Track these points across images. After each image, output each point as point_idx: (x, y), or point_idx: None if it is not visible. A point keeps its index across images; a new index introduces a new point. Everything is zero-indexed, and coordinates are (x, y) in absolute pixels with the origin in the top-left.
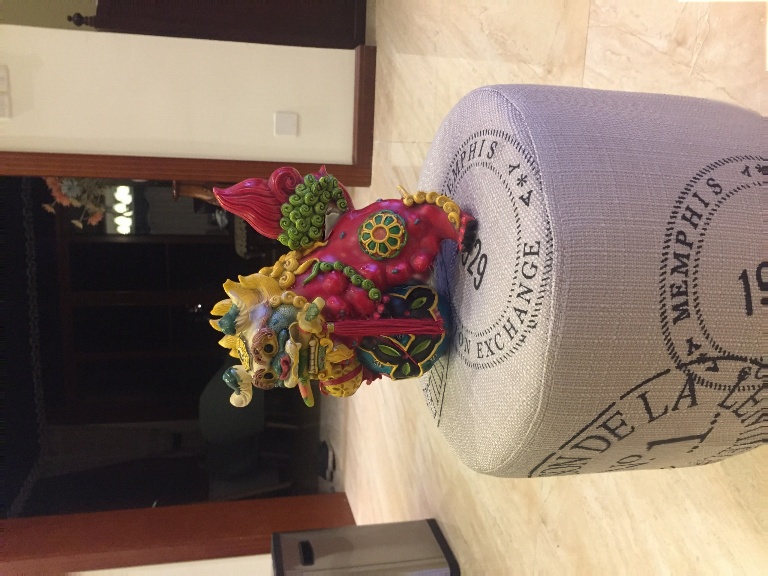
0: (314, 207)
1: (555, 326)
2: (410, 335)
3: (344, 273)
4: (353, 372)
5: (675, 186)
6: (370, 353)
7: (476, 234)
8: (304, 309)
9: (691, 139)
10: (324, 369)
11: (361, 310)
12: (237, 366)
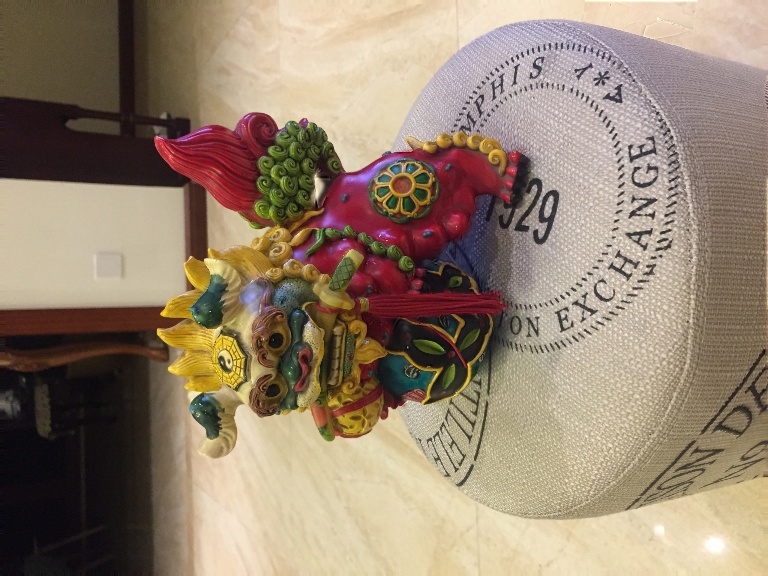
0: (301, 164)
1: (701, 237)
2: (458, 319)
3: (360, 240)
4: (376, 390)
5: (757, 90)
6: (402, 355)
7: (528, 175)
8: (321, 281)
9: None
10: (350, 376)
11: (390, 288)
12: None
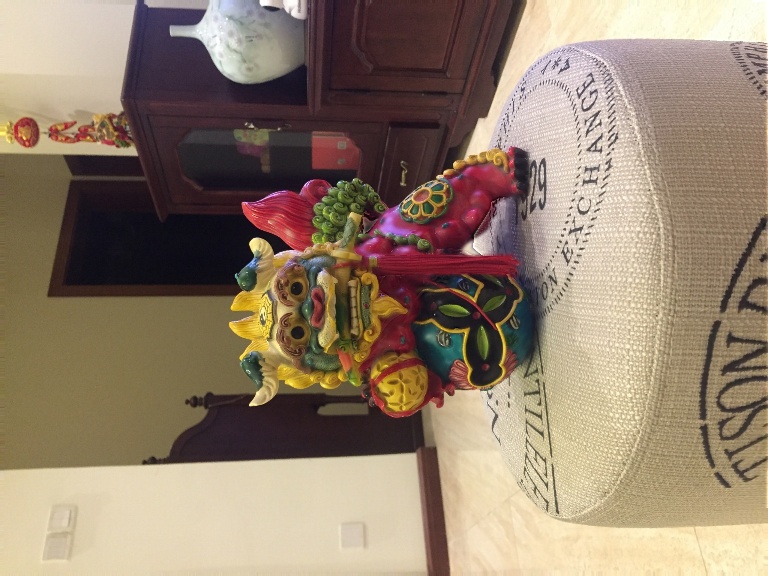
0: (349, 206)
1: (640, 119)
2: (477, 283)
3: (386, 237)
4: (413, 359)
5: None
6: (431, 322)
7: (528, 164)
8: None
9: None
10: (371, 326)
11: None
12: None
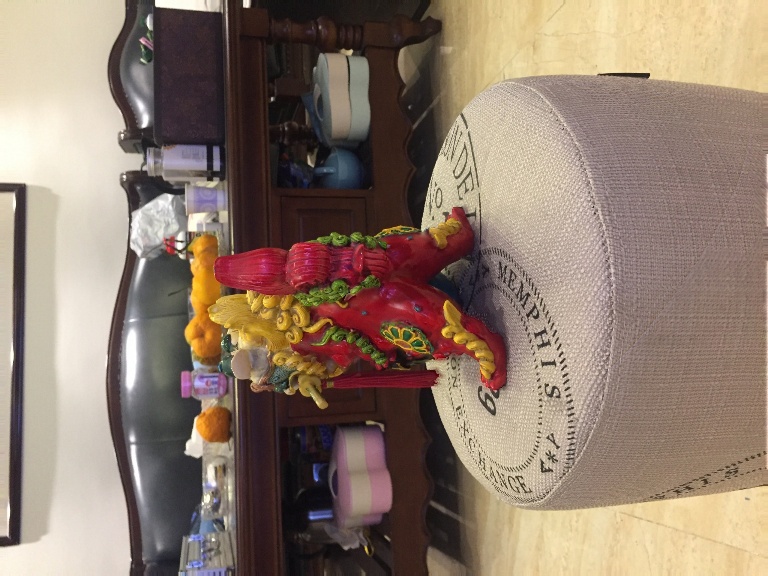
0: None
1: None
2: None
3: (356, 344)
4: None
5: None
6: None
7: None
8: (307, 373)
9: (764, 429)
10: None
11: (365, 358)
12: (235, 340)
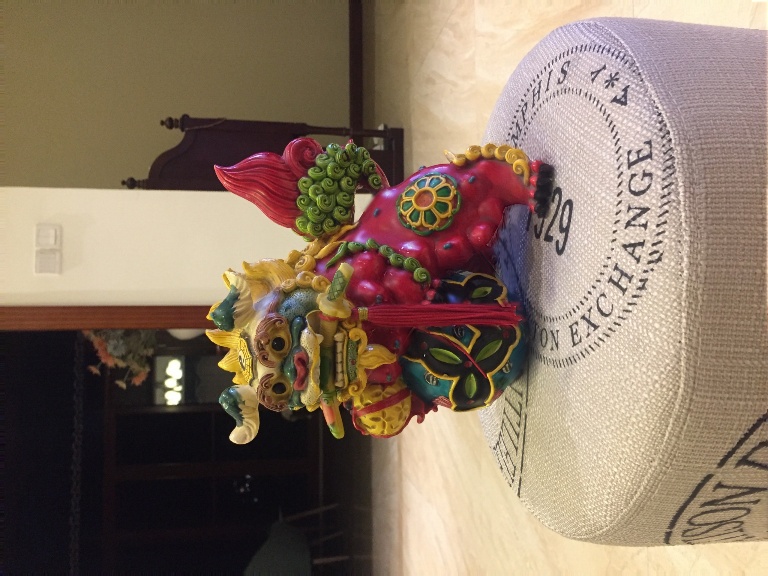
0: (340, 182)
1: (693, 249)
2: (473, 330)
3: (380, 252)
4: (398, 395)
5: None
6: (419, 362)
7: (552, 184)
8: (326, 291)
9: None
10: (356, 379)
11: (404, 298)
12: None
